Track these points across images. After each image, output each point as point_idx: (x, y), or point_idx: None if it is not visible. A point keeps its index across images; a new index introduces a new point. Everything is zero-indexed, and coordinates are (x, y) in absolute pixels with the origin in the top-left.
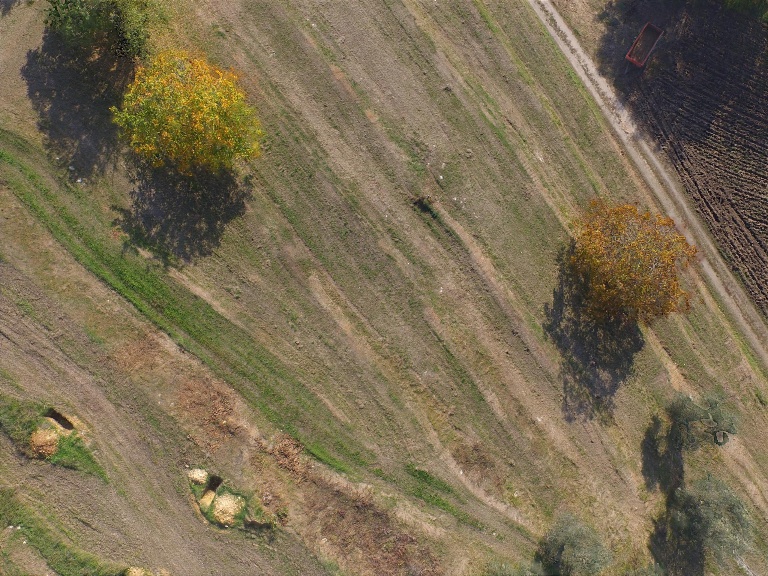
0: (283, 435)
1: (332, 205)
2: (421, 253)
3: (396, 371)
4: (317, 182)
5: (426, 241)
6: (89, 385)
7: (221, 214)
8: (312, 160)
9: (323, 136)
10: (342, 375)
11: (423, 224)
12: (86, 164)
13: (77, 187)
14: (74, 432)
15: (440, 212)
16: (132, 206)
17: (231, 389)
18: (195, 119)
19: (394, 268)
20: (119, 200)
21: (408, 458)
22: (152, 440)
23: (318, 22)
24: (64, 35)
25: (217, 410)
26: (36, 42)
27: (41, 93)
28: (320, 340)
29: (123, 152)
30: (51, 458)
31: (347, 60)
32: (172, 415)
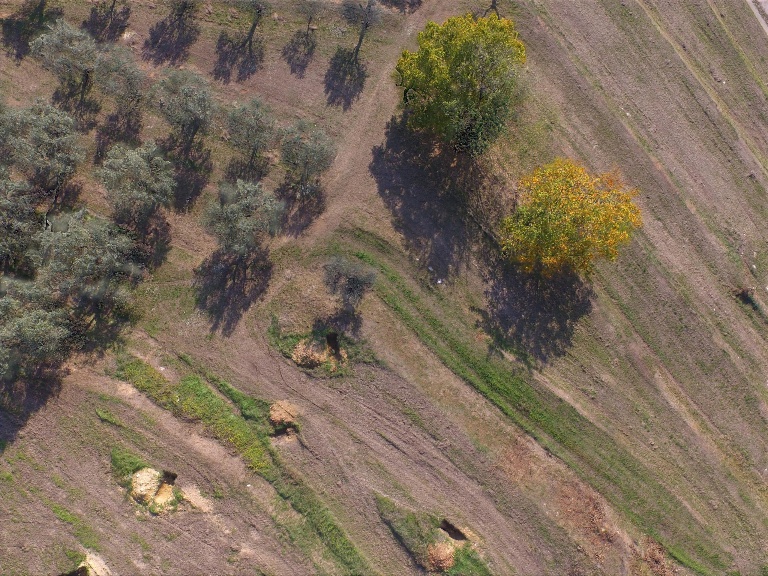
0: (648, 539)
1: (667, 300)
2: (747, 346)
3: (740, 469)
4: (651, 277)
5: (750, 333)
6: (479, 495)
7: (569, 312)
8: (645, 254)
9: (649, 228)
10: (694, 475)
11: (745, 316)
12: (441, 264)
13: (439, 289)
14: (468, 544)
15: (759, 303)
16: (487, 306)
17: (596, 493)
18: (608, 235)
19: (730, 364)
20: (475, 300)
21: (763, 560)
22: (543, 551)
23: (631, 111)
24: (405, 130)
25: (594, 517)
26: (379, 138)
27: (390, 191)
28: (671, 440)
29: (473, 250)
30: (448, 571)
31: (660, 149)
32: (562, 526)
